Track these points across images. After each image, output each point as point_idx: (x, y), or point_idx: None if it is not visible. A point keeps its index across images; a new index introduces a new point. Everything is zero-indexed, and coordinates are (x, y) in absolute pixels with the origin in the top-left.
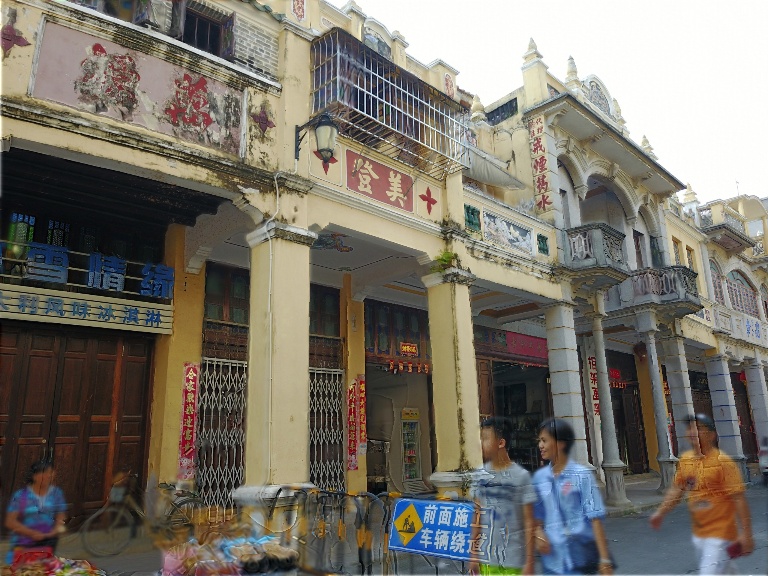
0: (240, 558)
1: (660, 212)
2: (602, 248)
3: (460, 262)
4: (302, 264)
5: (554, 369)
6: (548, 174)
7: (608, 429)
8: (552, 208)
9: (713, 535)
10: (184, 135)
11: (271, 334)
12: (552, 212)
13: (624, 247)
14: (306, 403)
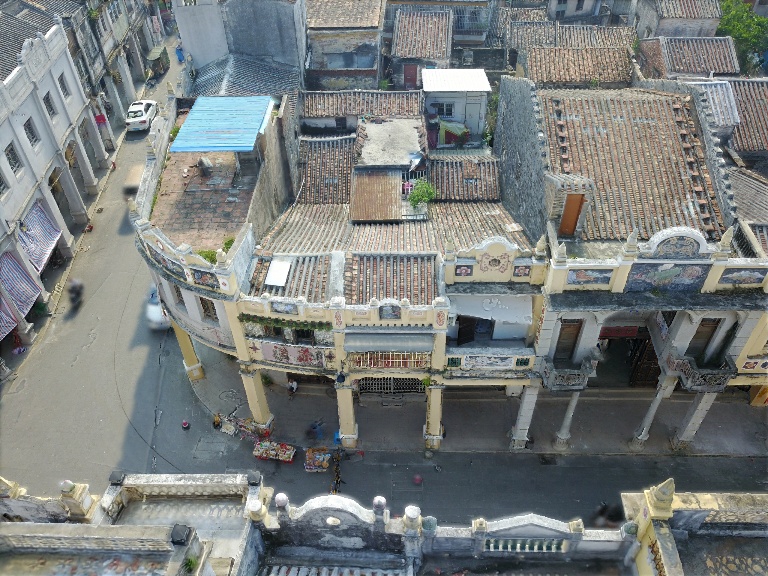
0: (316, 463)
1: (755, 311)
2: (552, 382)
3: (437, 381)
4: (348, 393)
5: (521, 402)
6: (541, 330)
7: (563, 424)
8: (537, 347)
9: (504, 505)
10: (305, 364)
11: (338, 408)
12: (537, 348)
13: (677, 331)
14: (352, 421)
